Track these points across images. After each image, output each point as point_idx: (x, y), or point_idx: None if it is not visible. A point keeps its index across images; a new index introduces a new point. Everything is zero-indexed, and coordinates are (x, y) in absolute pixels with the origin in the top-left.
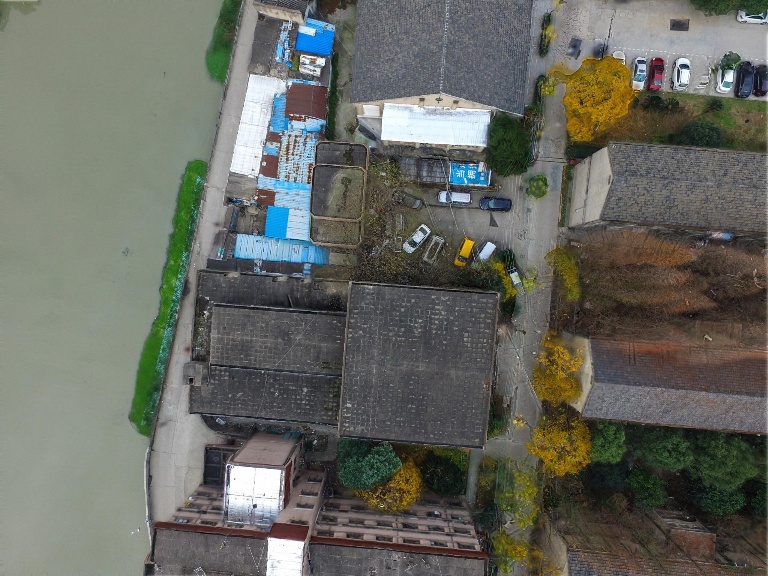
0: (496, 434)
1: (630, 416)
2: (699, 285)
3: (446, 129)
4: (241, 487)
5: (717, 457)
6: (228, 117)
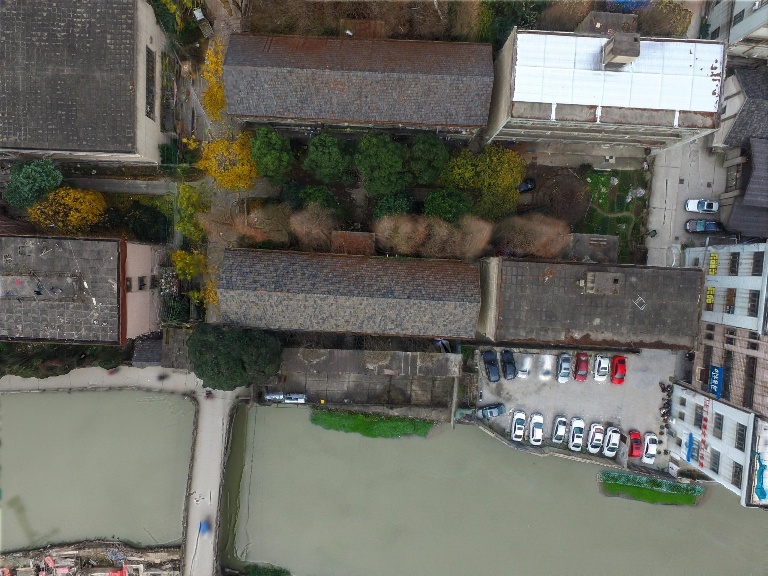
0: (197, 179)
1: (273, 110)
2: (387, 21)
3: None
4: None
5: (364, 151)
6: None
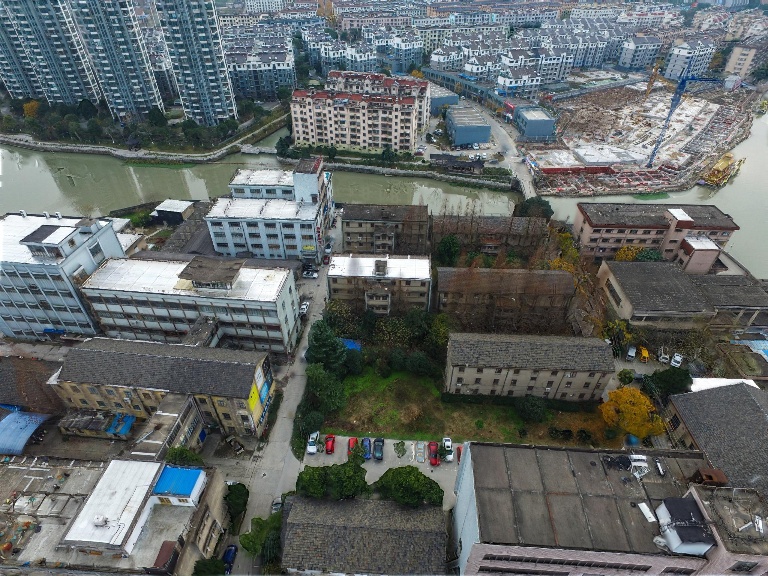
0: None
1: None
2: None
3: (716, 385)
4: (709, 244)
5: None
6: None
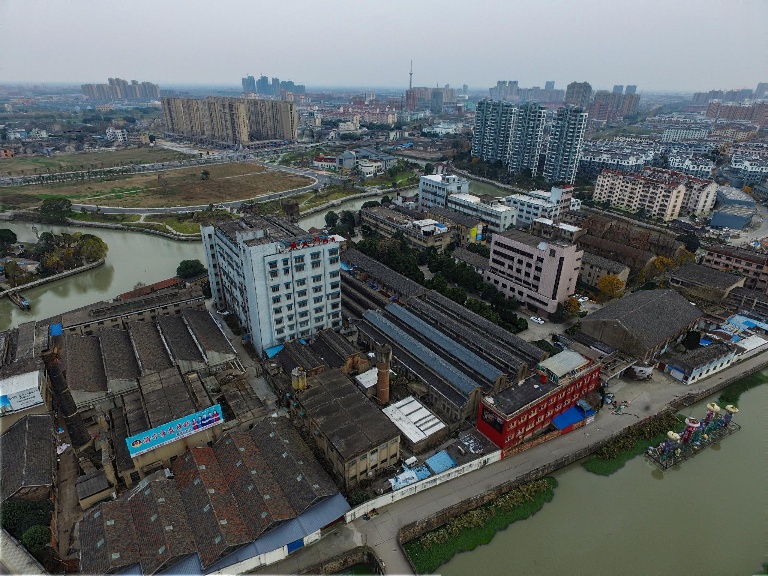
0: None
1: None
2: None
3: None
4: None
5: None
6: (763, 360)
